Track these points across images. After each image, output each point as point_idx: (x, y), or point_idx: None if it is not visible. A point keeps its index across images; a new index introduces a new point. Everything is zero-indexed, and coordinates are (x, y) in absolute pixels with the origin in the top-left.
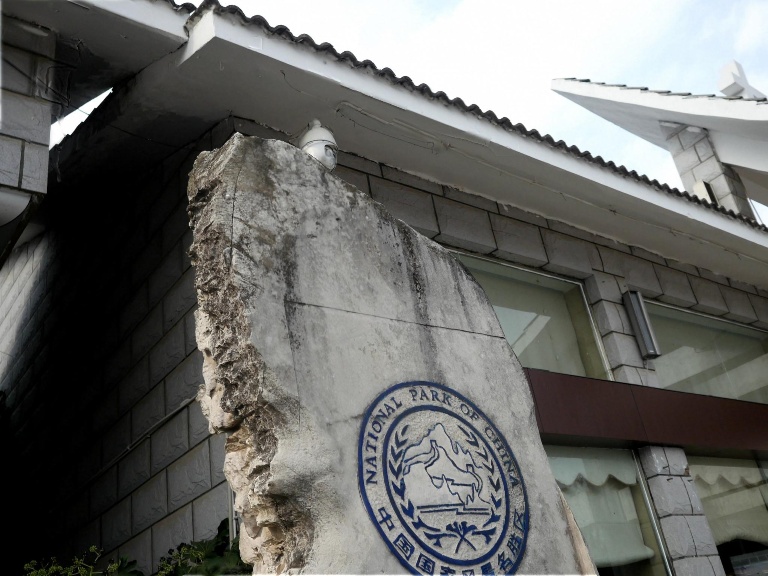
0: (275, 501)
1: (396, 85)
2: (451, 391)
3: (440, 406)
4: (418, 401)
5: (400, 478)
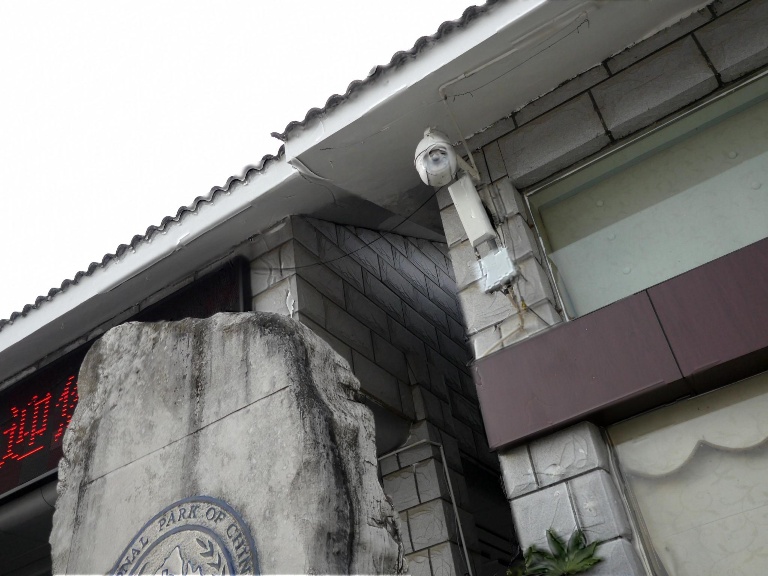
0: None
1: (471, 21)
2: (200, 499)
3: (184, 524)
4: (164, 529)
5: None
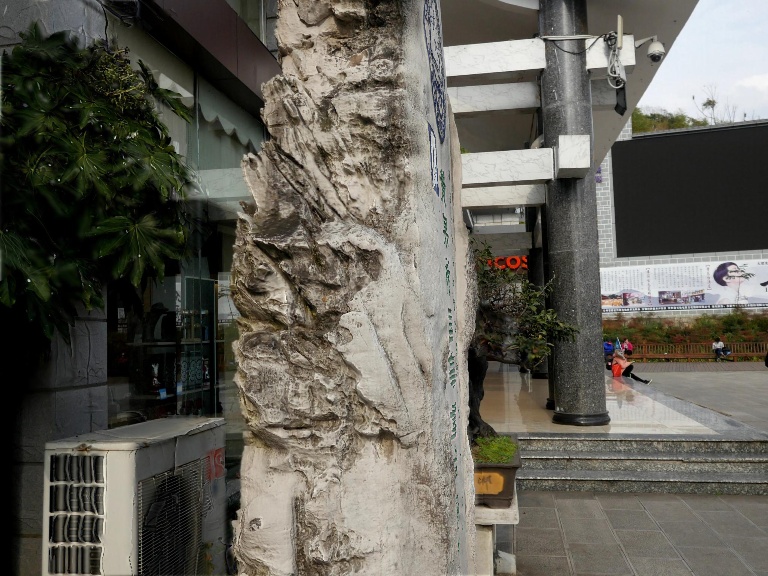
0: None
1: None
2: None
3: None
4: None
5: None
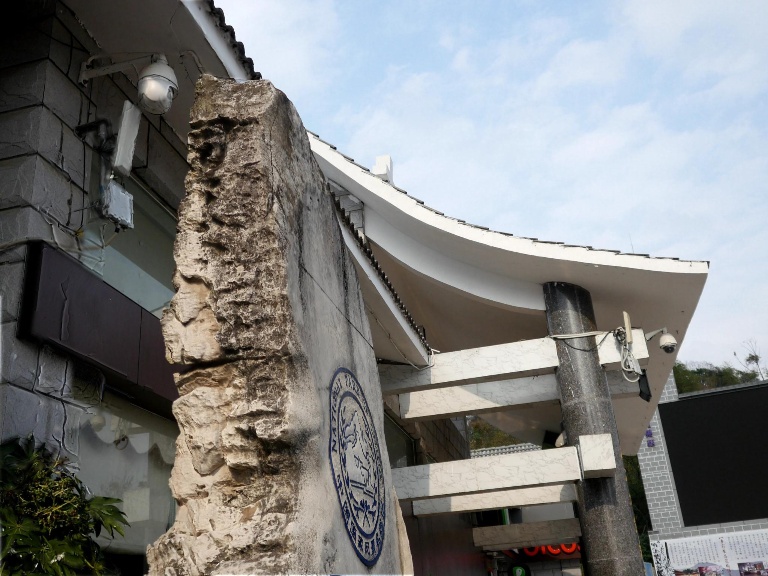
0: (271, 447)
1: (239, 61)
2: (359, 385)
3: None
4: (348, 387)
5: (344, 452)
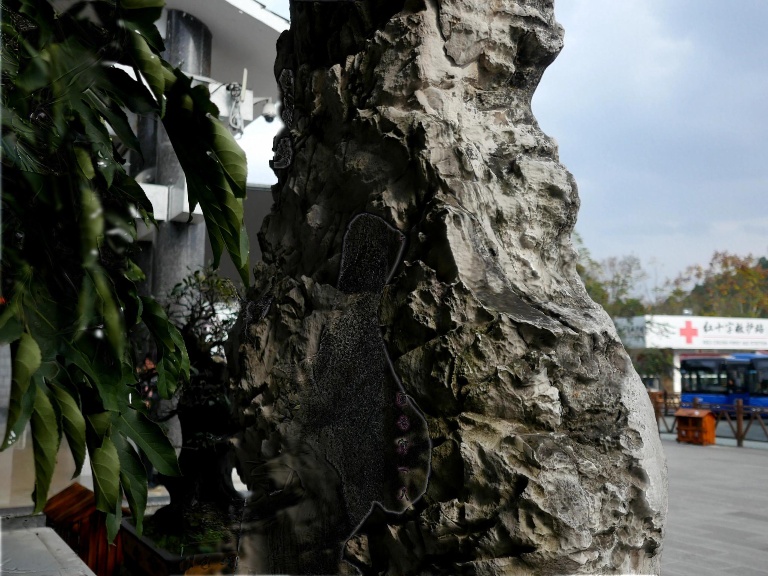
0: (535, 59)
1: None
2: None
3: None
4: None
5: None
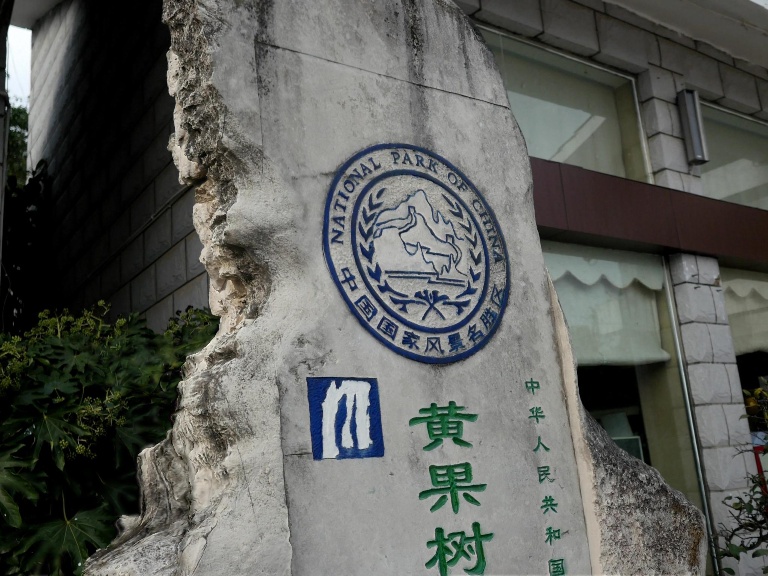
0: (233, 252)
1: None
2: (439, 158)
3: (424, 172)
4: (400, 165)
5: (370, 241)
